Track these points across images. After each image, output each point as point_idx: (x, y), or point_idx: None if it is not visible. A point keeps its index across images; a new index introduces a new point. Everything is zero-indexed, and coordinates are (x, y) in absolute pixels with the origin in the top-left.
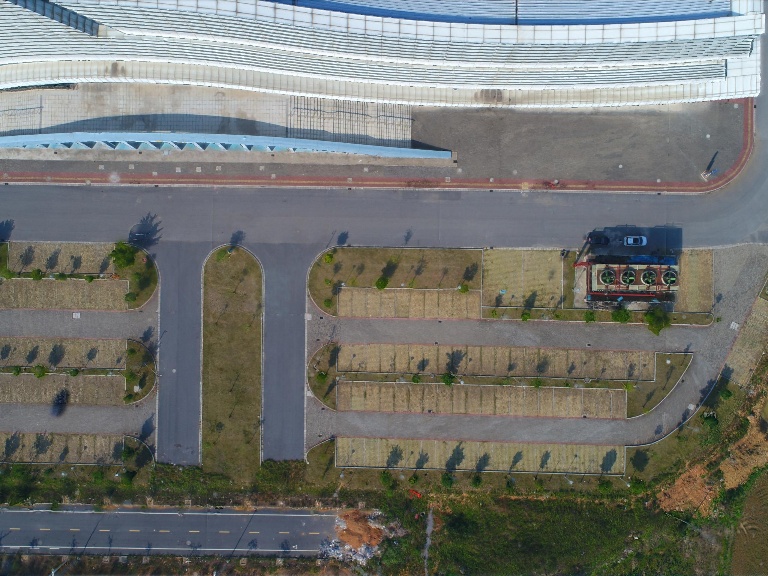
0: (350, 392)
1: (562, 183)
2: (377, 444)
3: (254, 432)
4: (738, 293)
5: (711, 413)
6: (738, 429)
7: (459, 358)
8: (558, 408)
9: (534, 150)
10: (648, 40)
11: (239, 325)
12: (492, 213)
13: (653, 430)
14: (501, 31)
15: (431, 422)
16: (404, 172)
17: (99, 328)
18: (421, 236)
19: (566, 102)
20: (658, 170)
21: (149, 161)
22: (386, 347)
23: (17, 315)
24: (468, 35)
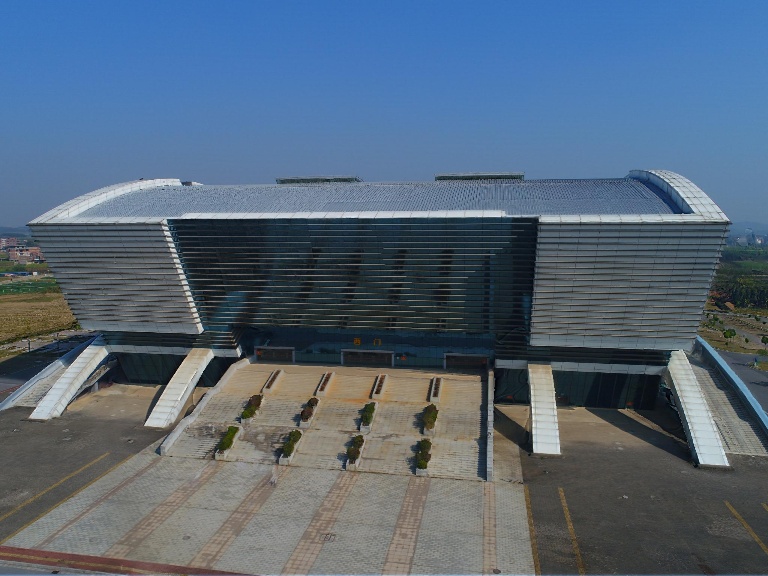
0: None
1: None
2: None
3: None
4: None
5: None
6: None
7: None
8: None
9: None
10: None
11: None
12: None
13: None
14: None
15: None
16: None
17: None
18: None
19: None
20: None
21: None
22: None
23: None
24: None
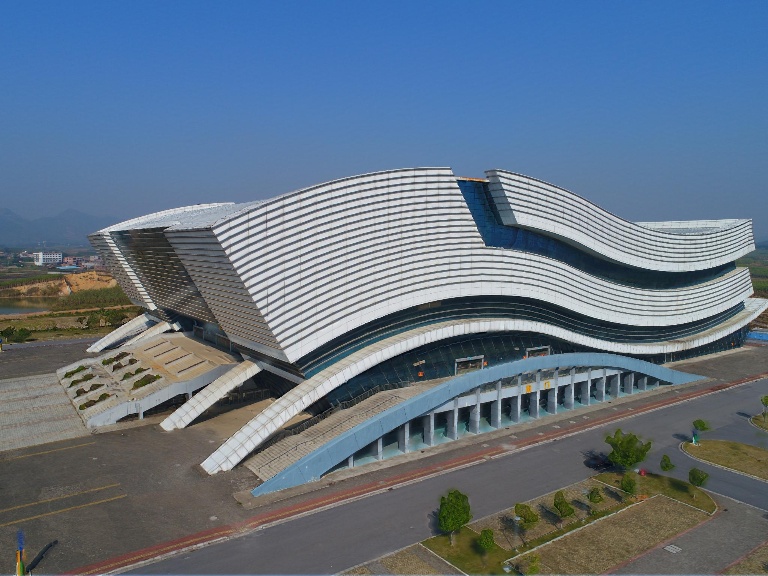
0: None
1: None
2: None
3: None
4: None
5: None
6: None
7: None
8: None
9: (734, 367)
10: (724, 229)
11: None
12: None
13: None
14: None
15: None
16: (699, 387)
17: (722, 546)
18: None
19: None
20: None
21: None
22: None
23: None
24: None
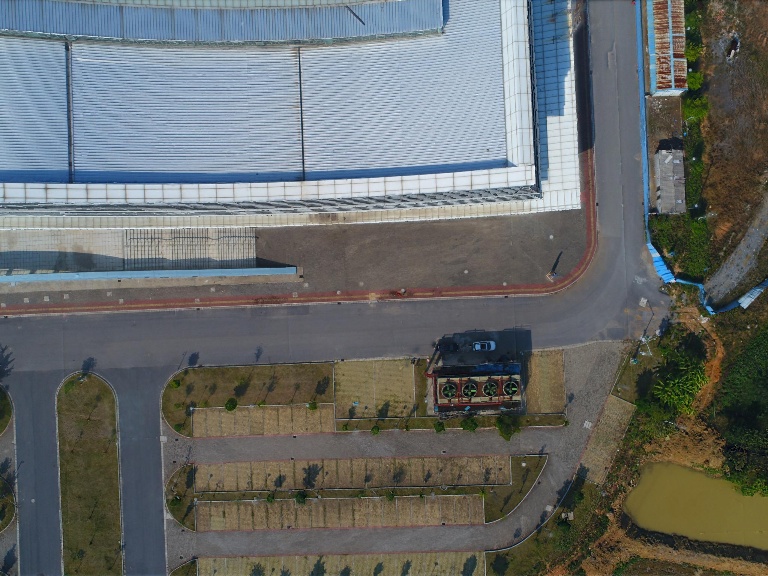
0: (209, 512)
1: (409, 292)
2: (238, 563)
3: (116, 558)
4: (590, 392)
5: (569, 514)
6: (597, 528)
7: (315, 472)
8: (416, 517)
9: (379, 261)
10: (428, 191)
11: (95, 452)
12: (341, 325)
13: (512, 534)
14: (285, 188)
15: (291, 538)
16: (251, 290)
17: None
18: (271, 352)
19: (399, 218)
20: (503, 273)
21: None
22: (242, 465)
23: None
24: (252, 194)
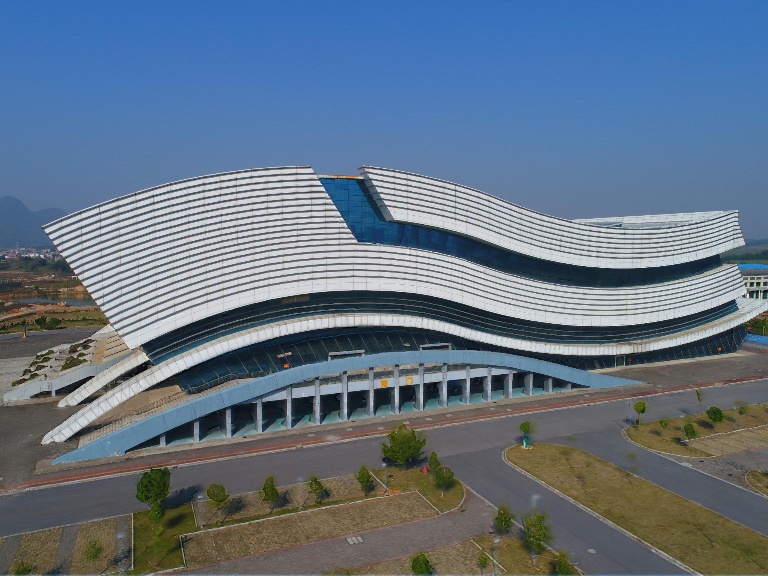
0: None
1: (740, 379)
2: None
3: None
4: None
5: None
6: None
7: None
8: None
9: None
10: (694, 222)
11: (617, 487)
12: None
13: None
14: None
15: None
16: (619, 392)
17: (408, 542)
18: (693, 409)
19: None
20: None
21: (367, 424)
22: None
23: (230, 568)
24: None
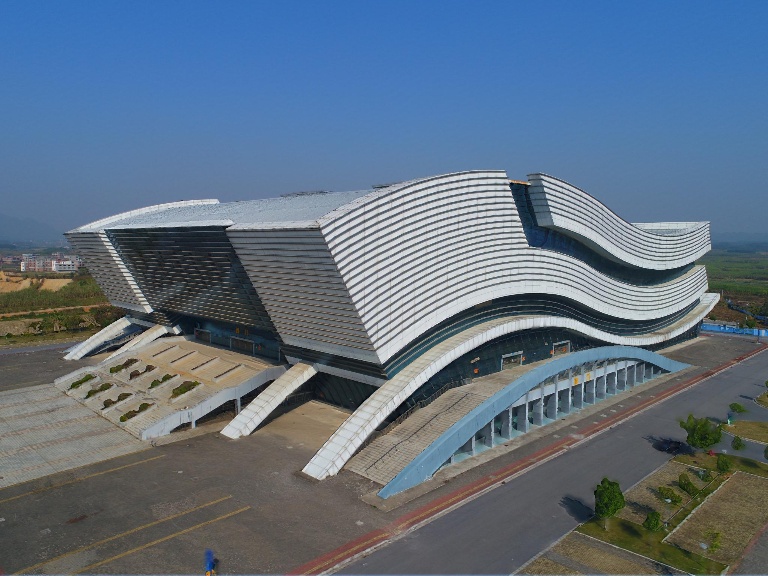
0: None
1: None
2: None
3: None
4: None
5: None
6: None
7: None
8: None
9: None
10: (692, 231)
11: None
12: None
13: None
14: None
15: None
16: (692, 374)
17: None
18: (762, 383)
19: None
20: None
21: (577, 421)
22: None
23: (759, 559)
24: None
